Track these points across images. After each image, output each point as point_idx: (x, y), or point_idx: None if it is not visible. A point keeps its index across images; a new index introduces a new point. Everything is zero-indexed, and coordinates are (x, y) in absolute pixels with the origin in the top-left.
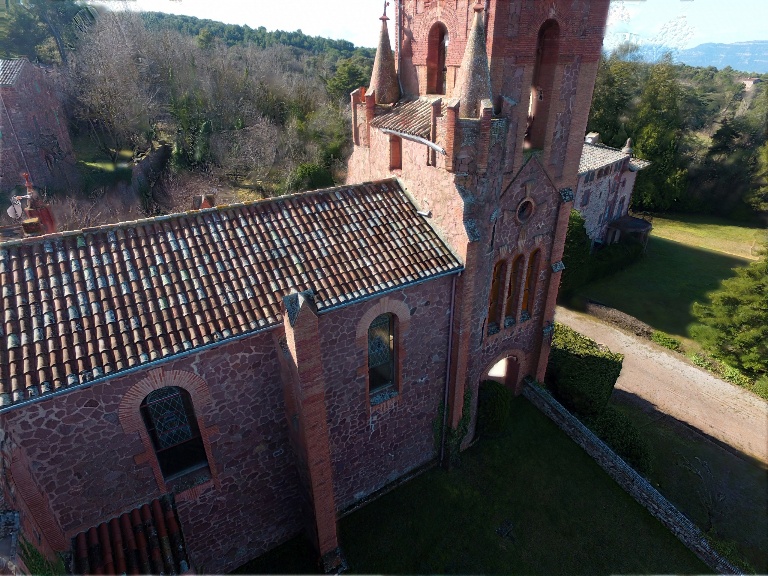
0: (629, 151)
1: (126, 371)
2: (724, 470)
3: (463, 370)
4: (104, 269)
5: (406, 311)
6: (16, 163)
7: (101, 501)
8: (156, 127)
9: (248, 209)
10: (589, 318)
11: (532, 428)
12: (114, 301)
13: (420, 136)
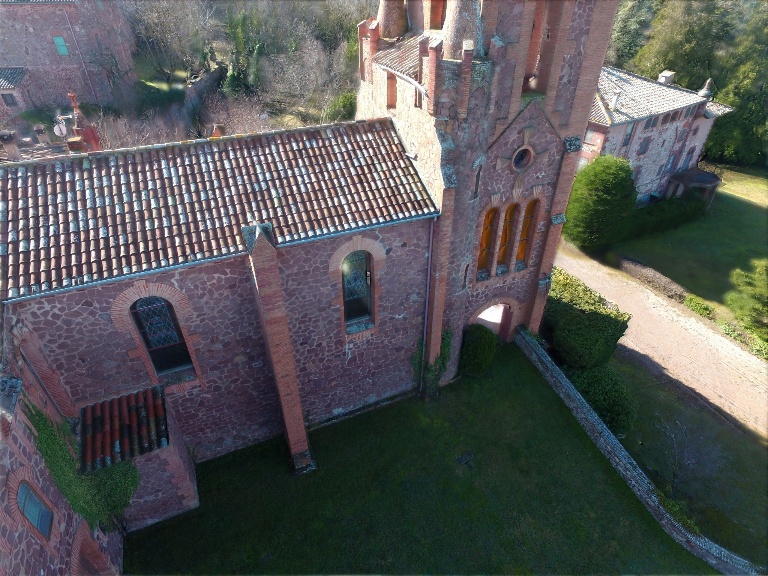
0: (707, 94)
1: (110, 280)
2: (718, 439)
3: (440, 311)
4: (103, 190)
5: (381, 250)
6: (81, 81)
7: (103, 383)
8: (211, 48)
9: (239, 142)
10: (621, 275)
11: (516, 374)
12: (108, 219)
13: (409, 76)
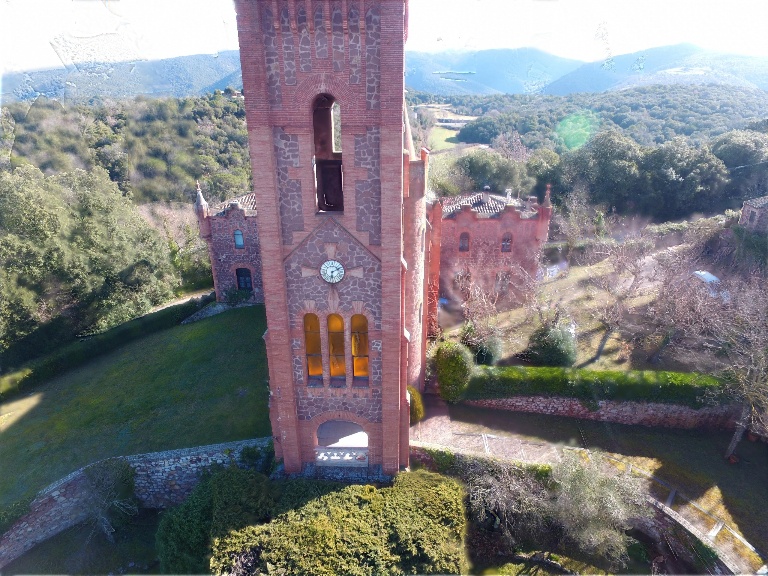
0: None
1: None
2: None
3: None
4: None
5: None
6: None
7: None
8: None
9: None
10: None
11: None
12: None
13: None
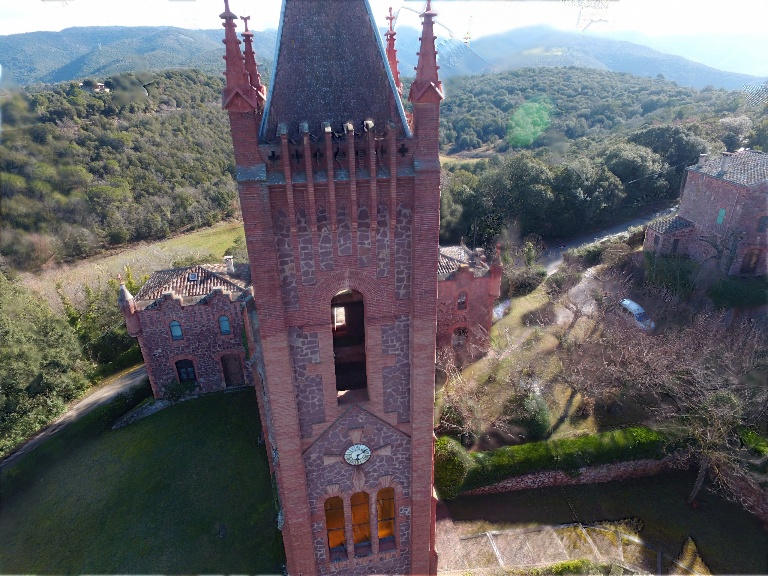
0: None
1: None
2: None
3: None
4: None
5: None
6: None
7: None
8: None
9: None
10: None
11: None
12: None
13: None
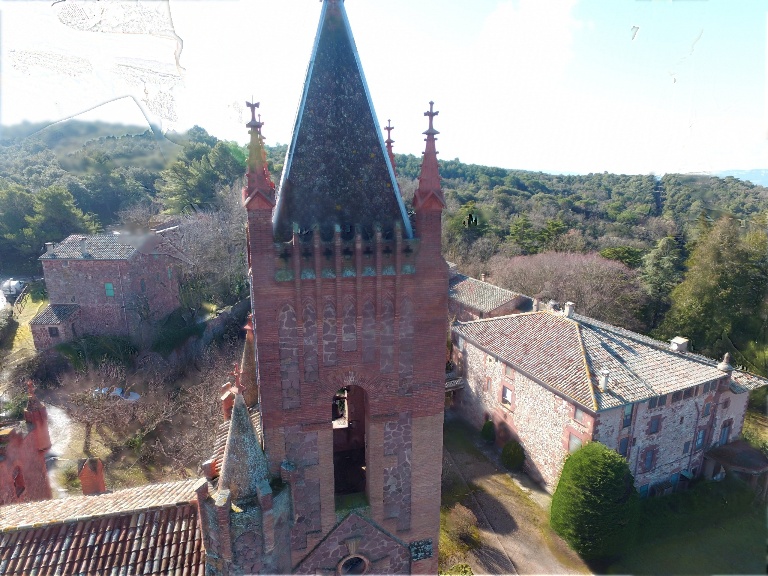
0: (727, 369)
1: None
2: None
3: None
4: None
5: None
6: (119, 316)
7: None
8: (247, 282)
9: (35, 532)
10: None
11: None
12: None
13: None
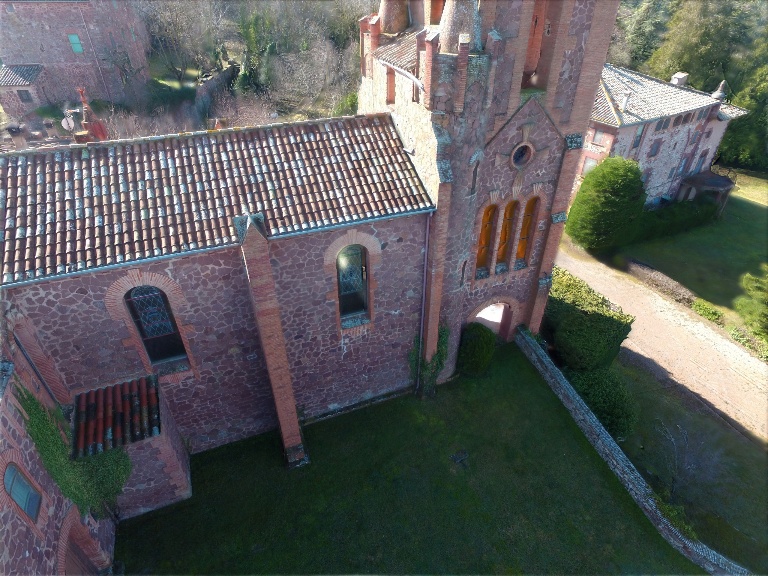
0: (720, 96)
1: (104, 267)
2: (722, 445)
3: (437, 308)
4: (100, 180)
5: (376, 245)
6: (95, 78)
7: (98, 371)
8: (223, 47)
9: (237, 135)
10: (629, 278)
11: (515, 374)
12: (104, 208)
13: (407, 70)
